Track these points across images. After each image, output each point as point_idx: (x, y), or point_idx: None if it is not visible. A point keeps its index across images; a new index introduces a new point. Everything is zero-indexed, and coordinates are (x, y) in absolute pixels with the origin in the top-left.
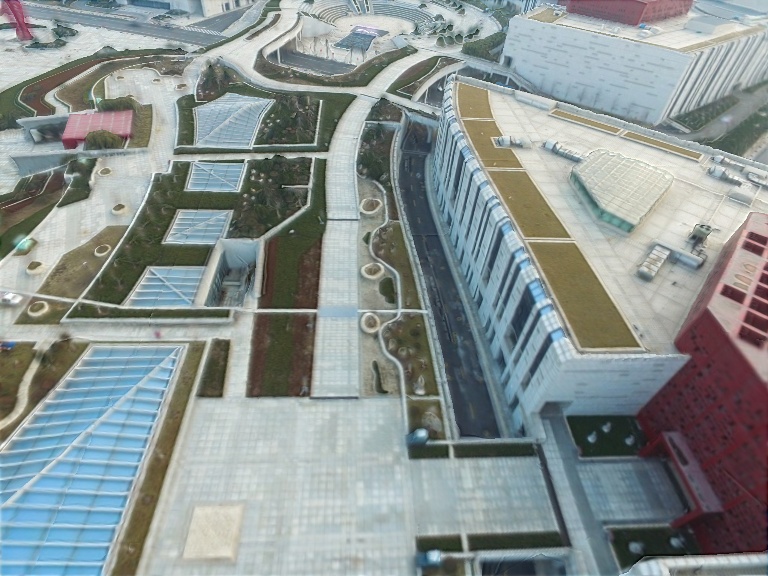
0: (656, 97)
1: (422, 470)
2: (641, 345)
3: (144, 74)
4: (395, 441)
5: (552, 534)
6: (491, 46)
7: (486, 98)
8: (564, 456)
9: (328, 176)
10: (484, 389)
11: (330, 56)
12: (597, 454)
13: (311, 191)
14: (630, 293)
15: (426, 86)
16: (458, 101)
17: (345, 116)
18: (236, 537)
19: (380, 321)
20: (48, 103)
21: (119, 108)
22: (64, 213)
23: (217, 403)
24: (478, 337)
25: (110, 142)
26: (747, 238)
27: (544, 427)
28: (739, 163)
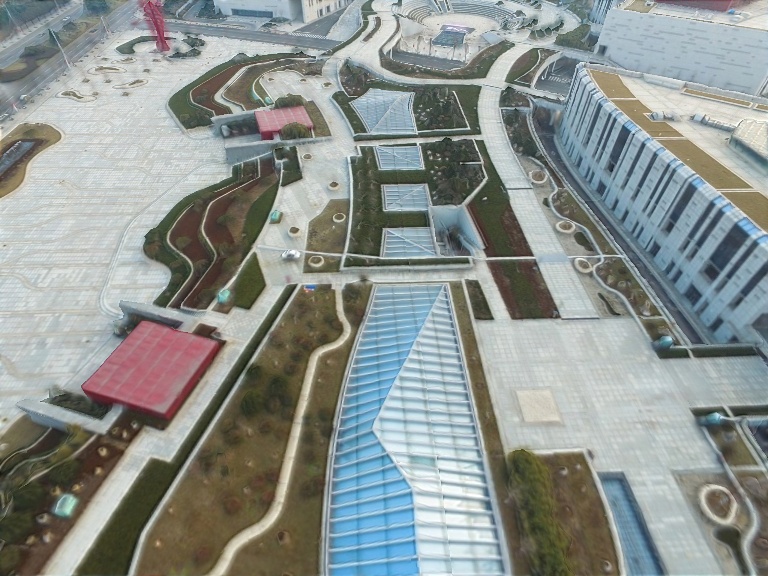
0: (752, 76)
1: (673, 366)
2: None
3: (288, 75)
4: (643, 347)
5: None
6: (580, 37)
7: (620, 81)
8: None
9: (491, 154)
10: (682, 316)
11: (433, 53)
12: None
13: (483, 167)
14: None
15: (537, 75)
16: (598, 85)
17: (480, 104)
18: (557, 409)
19: (591, 264)
20: (221, 104)
21: (293, 104)
22: (290, 191)
23: (493, 324)
24: (660, 279)
25: (303, 132)
26: None
27: (759, 335)
28: None
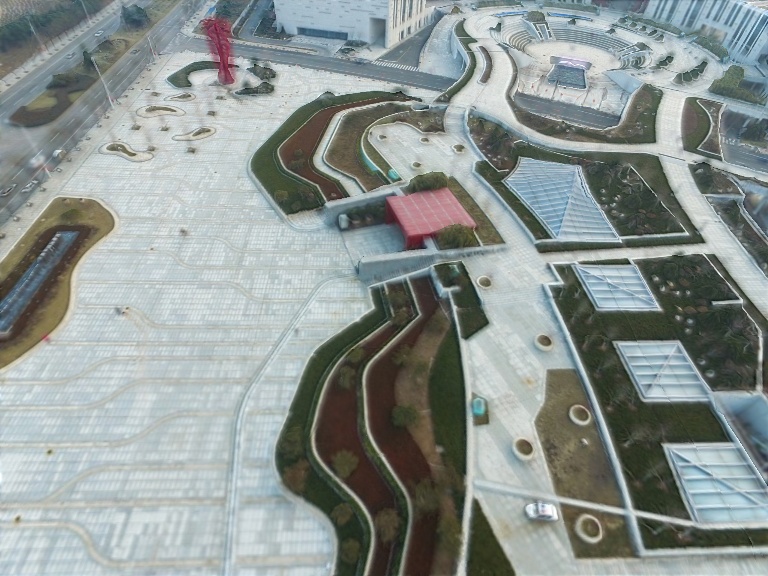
0: None
1: None
2: None
3: (401, 131)
4: None
5: None
6: None
7: None
8: None
9: (738, 281)
10: None
11: (557, 97)
12: None
13: (743, 307)
14: None
15: None
16: None
17: (673, 187)
18: None
19: None
20: (325, 174)
21: (435, 186)
22: (479, 349)
23: None
24: None
25: (469, 240)
26: None
27: None
28: None
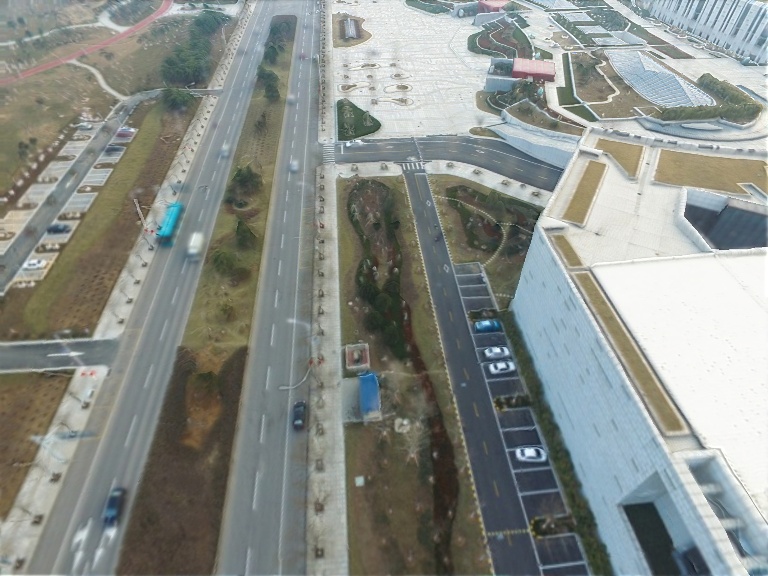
0: None
1: (752, 67)
2: None
3: None
4: None
5: None
6: None
7: None
8: None
9: (625, 16)
10: None
11: None
12: None
13: None
14: None
15: None
16: None
17: None
18: None
19: None
20: (445, 2)
21: None
22: None
23: None
24: None
25: (518, 7)
26: None
27: None
28: None
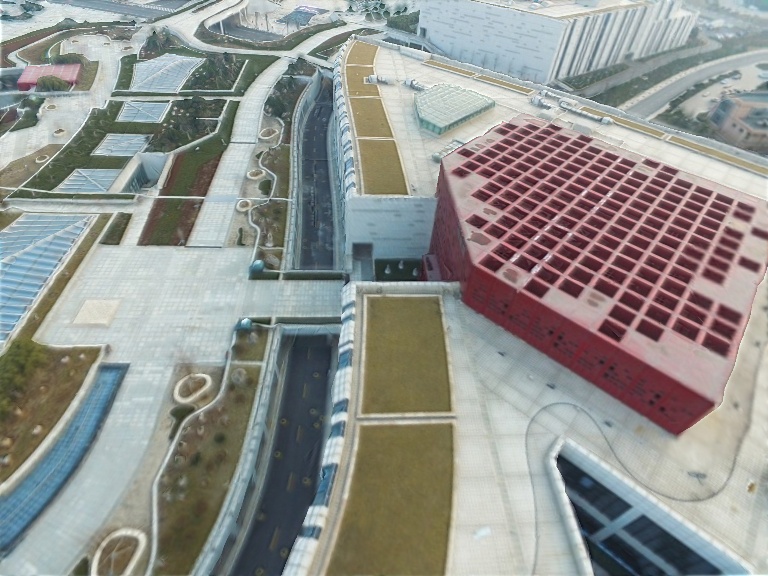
0: (542, 60)
1: (256, 286)
2: (409, 194)
3: (97, 39)
4: (241, 270)
5: (337, 318)
6: (414, 21)
7: (374, 52)
8: None
9: (238, 113)
10: (330, 254)
11: (270, 29)
12: (388, 279)
13: (221, 123)
14: (421, 169)
15: None
16: (349, 53)
17: (265, 72)
18: (112, 315)
19: (252, 204)
20: (10, 60)
21: (69, 62)
22: (14, 135)
23: (114, 248)
24: (337, 224)
25: (57, 85)
26: (502, 126)
27: (353, 263)
28: (558, 95)
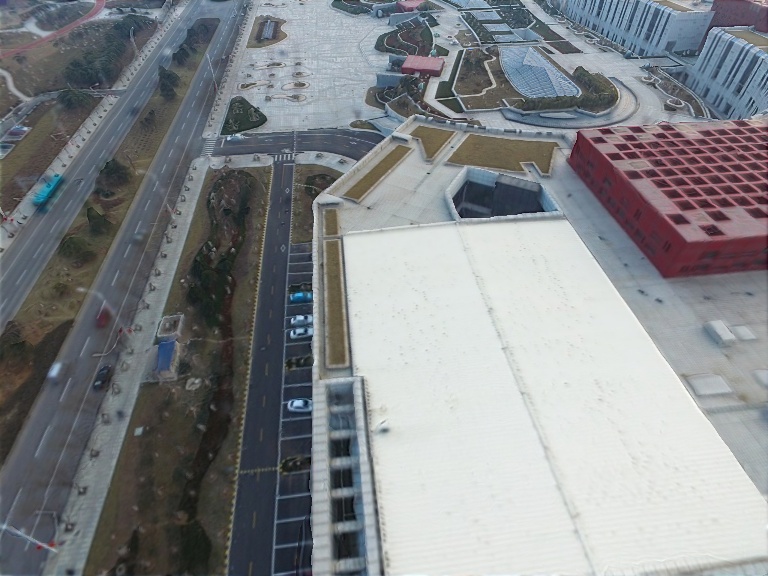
0: None
1: (632, 60)
2: None
3: None
4: (620, 57)
5: None
6: None
7: None
8: (676, 57)
9: (534, 14)
10: None
11: None
12: (687, 56)
13: None
14: (691, 7)
15: None
16: None
17: None
18: None
19: None
20: (367, 3)
21: None
22: (436, 28)
23: None
24: None
25: (431, 7)
26: None
27: None
28: None
